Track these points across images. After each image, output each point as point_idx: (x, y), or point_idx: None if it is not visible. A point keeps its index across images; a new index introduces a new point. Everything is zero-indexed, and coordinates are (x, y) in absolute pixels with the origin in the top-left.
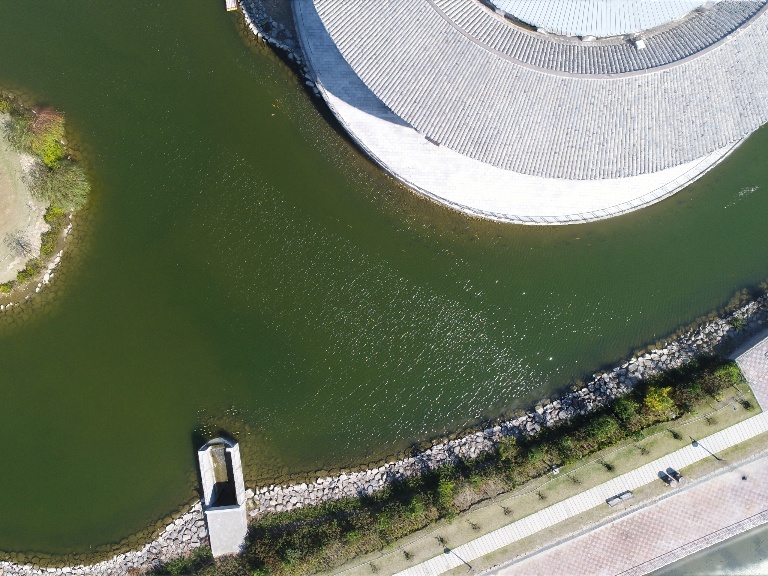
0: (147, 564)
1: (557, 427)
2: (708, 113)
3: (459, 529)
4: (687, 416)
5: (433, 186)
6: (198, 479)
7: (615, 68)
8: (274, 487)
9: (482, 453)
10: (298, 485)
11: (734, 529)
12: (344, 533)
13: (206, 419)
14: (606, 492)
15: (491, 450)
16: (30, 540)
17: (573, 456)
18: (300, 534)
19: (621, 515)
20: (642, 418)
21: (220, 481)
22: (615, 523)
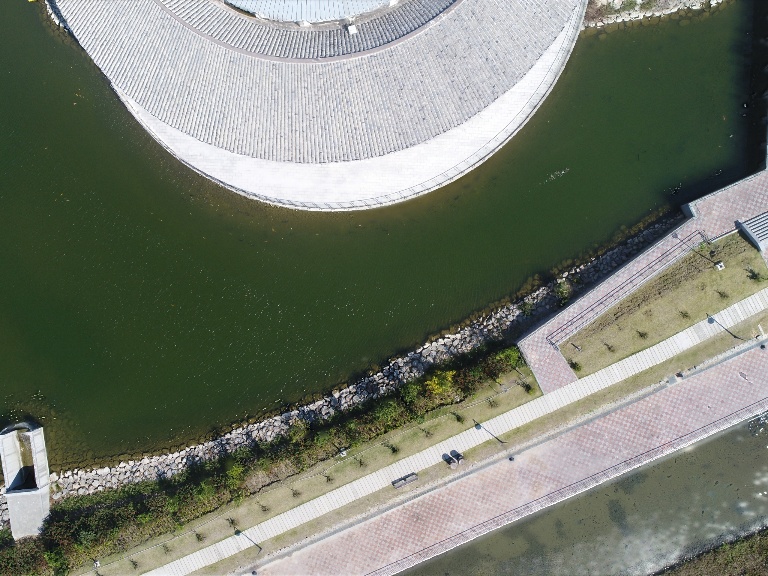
0: None
1: (349, 411)
2: (425, 97)
3: (249, 511)
4: (470, 399)
5: (220, 173)
6: None
7: (325, 53)
8: (78, 471)
9: (277, 437)
10: (101, 469)
11: (522, 511)
12: None
13: (13, 404)
14: (392, 474)
15: (286, 434)
16: None
17: (359, 439)
18: (97, 517)
19: (412, 497)
20: (428, 401)
21: (27, 465)
22: (406, 505)
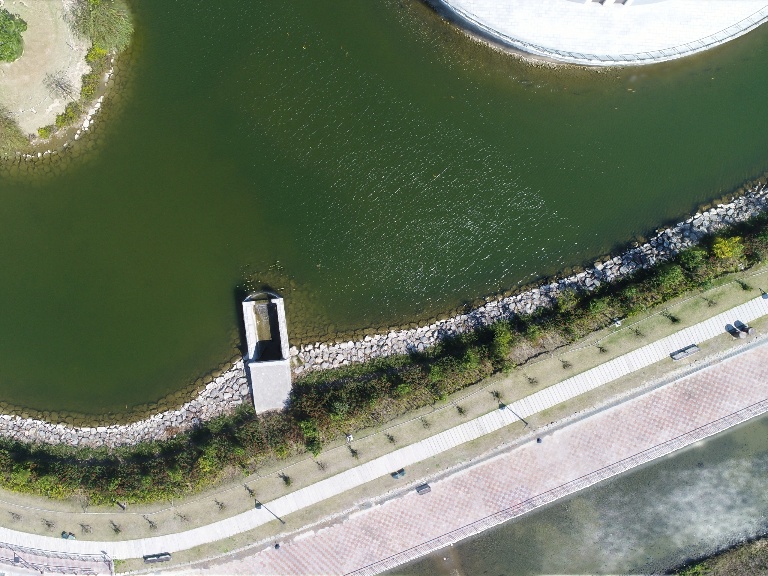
0: (186, 423)
1: (618, 281)
2: None
3: (515, 384)
4: (757, 266)
5: (495, 22)
6: (240, 336)
7: None
8: (320, 345)
9: (539, 308)
10: (345, 343)
11: None
12: (394, 387)
13: (249, 274)
14: (670, 346)
15: (548, 305)
16: (64, 400)
17: (637, 307)
18: (348, 389)
19: (684, 374)
20: (709, 269)
21: (263, 339)
22: (677, 382)
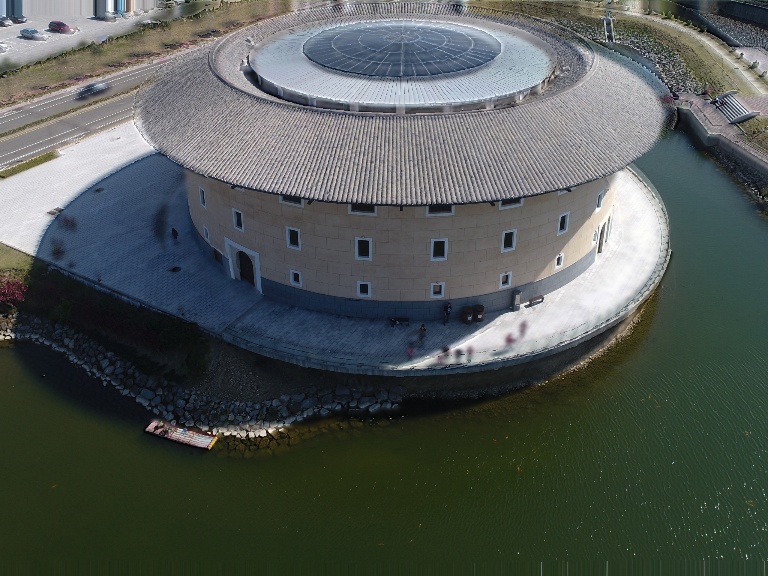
0: None
1: None
2: None
3: None
4: None
5: None
6: None
7: None
8: None
9: None
10: None
11: None
12: None
13: None
14: None
15: None
16: None
17: None
18: None
19: None
20: None
21: None
22: None
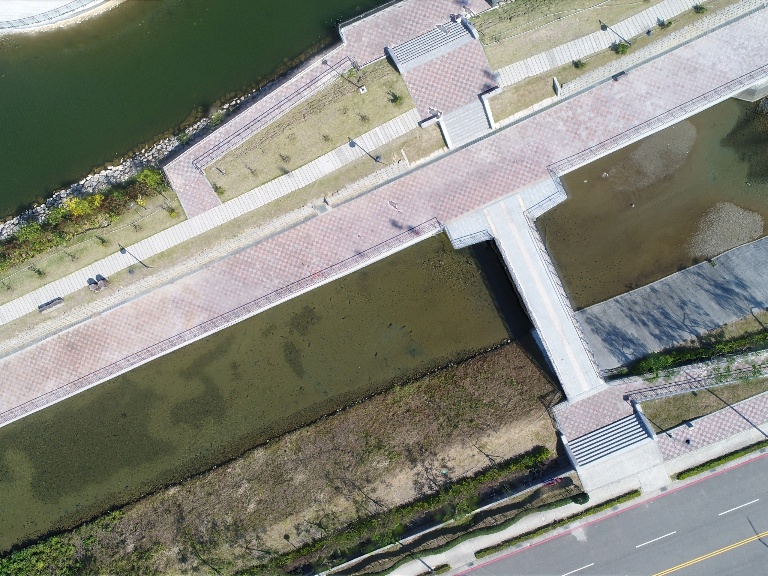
0: None
1: (7, 239)
2: None
3: None
4: (115, 223)
5: None
6: None
7: None
8: None
9: None
10: None
11: (175, 341)
12: None
13: None
14: (38, 299)
15: None
16: None
17: (5, 262)
18: None
19: (67, 327)
20: None
21: None
22: (61, 334)
